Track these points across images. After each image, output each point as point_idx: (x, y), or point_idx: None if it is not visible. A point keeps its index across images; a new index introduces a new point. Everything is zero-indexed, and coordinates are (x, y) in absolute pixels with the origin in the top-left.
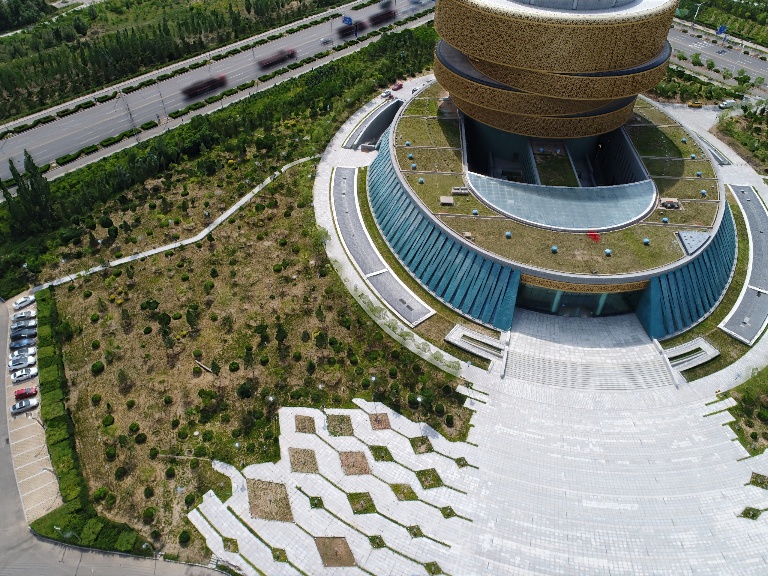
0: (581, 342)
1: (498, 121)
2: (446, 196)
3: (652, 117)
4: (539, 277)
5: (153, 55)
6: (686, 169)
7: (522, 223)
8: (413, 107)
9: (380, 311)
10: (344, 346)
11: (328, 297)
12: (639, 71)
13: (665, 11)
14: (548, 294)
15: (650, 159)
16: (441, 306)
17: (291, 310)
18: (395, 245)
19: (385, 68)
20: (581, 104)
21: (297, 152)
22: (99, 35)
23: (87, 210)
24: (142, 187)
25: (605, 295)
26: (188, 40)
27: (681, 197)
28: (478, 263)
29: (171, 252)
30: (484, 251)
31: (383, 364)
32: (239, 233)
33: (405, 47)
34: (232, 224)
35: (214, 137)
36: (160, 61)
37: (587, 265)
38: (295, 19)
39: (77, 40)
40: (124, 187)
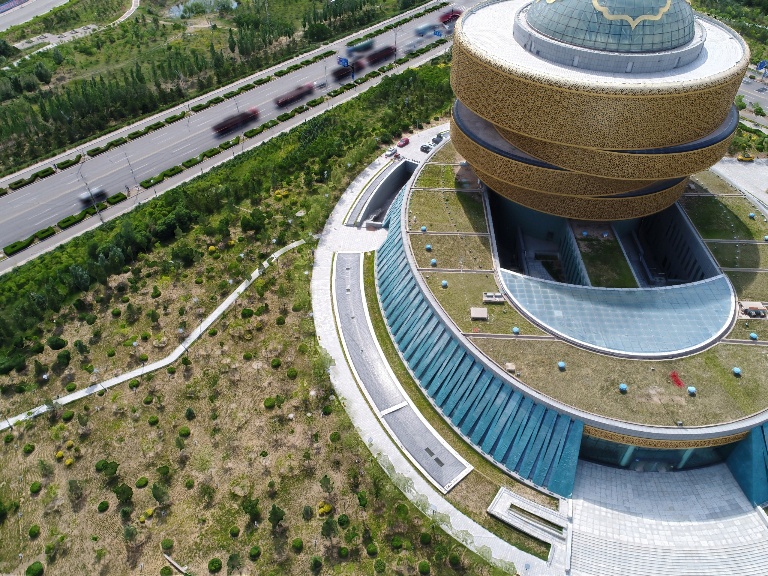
0: (664, 513)
1: (532, 200)
2: (477, 306)
3: (707, 183)
4: (608, 430)
5: (124, 106)
6: (762, 257)
7: (576, 345)
8: (426, 176)
9: (404, 484)
10: (358, 526)
11: (334, 447)
12: (707, 144)
13: (739, 72)
14: (618, 448)
15: (716, 243)
16: (479, 458)
17: (288, 469)
18: (415, 367)
19: (388, 118)
20: (634, 181)
21: (290, 232)
22: (65, 81)
23: (36, 320)
24: (105, 285)
25: (692, 449)
26: (165, 86)
27: (765, 299)
28: (526, 407)
29: (137, 382)
30: (534, 393)
31: (412, 562)
32: (222, 350)
33: (409, 92)
34: (213, 337)
35: (192, 215)
36: (132, 114)
37: (668, 412)
38: (284, 59)
39: (39, 90)
40: (82, 289)
